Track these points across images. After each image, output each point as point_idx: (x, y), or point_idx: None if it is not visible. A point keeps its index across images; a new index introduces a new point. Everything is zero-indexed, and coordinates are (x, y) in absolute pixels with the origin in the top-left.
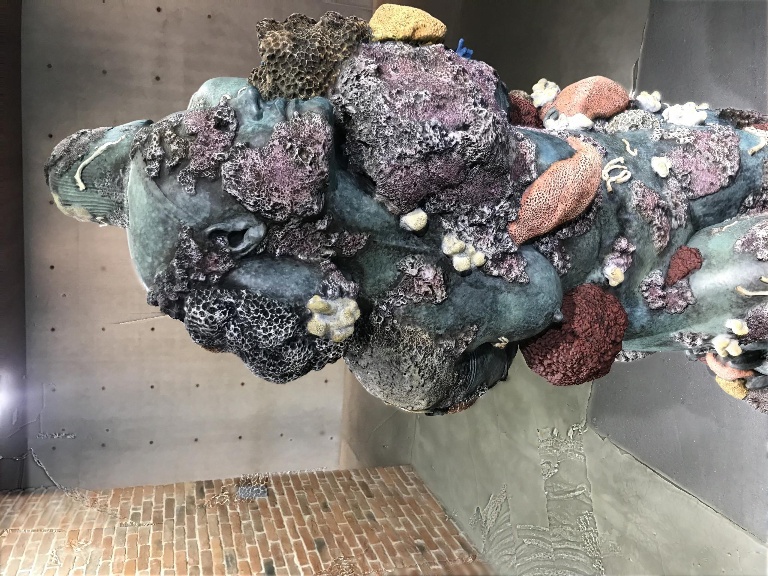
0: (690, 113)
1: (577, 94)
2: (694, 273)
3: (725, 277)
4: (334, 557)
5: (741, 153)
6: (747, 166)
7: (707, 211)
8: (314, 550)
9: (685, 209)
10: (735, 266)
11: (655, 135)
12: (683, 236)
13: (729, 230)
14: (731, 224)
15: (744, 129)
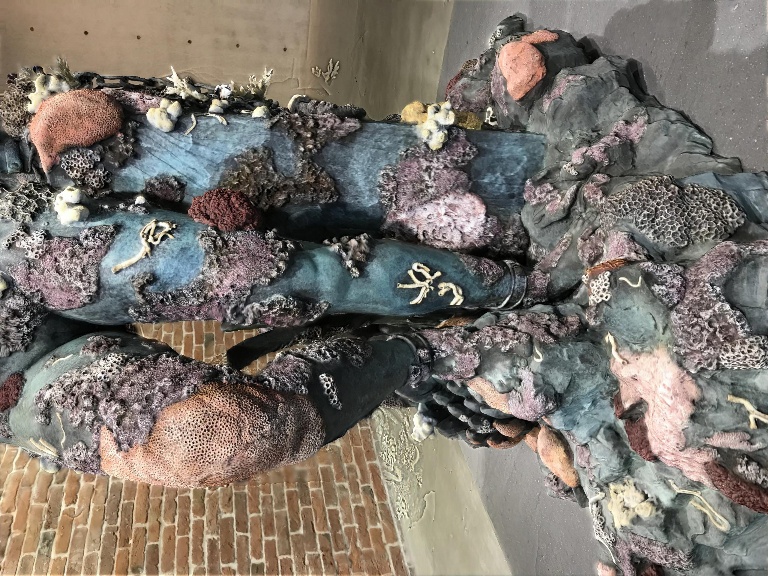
0: (60, 212)
1: (38, 121)
2: (13, 408)
3: (24, 424)
4: (217, 353)
5: (102, 271)
6: (110, 285)
7: (89, 317)
8: (202, 344)
9: (27, 332)
10: (30, 417)
11: (5, 242)
12: (22, 361)
13: (54, 368)
14: (64, 358)
15: (148, 223)
